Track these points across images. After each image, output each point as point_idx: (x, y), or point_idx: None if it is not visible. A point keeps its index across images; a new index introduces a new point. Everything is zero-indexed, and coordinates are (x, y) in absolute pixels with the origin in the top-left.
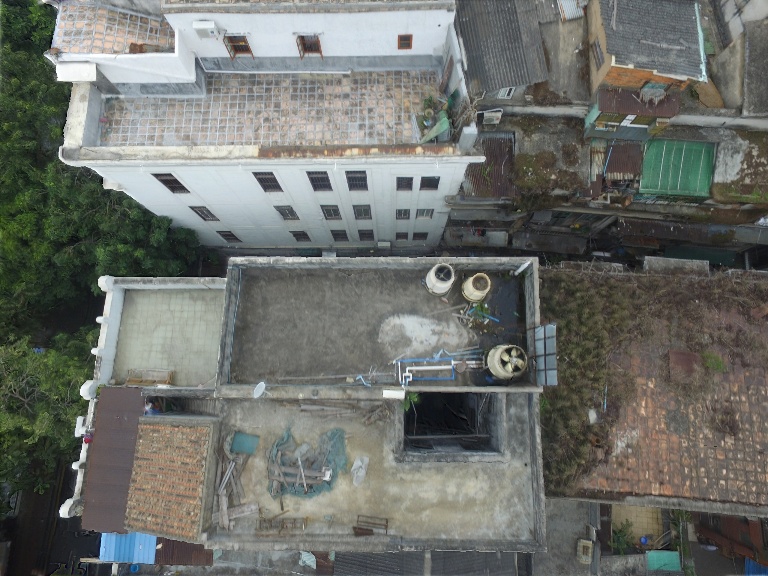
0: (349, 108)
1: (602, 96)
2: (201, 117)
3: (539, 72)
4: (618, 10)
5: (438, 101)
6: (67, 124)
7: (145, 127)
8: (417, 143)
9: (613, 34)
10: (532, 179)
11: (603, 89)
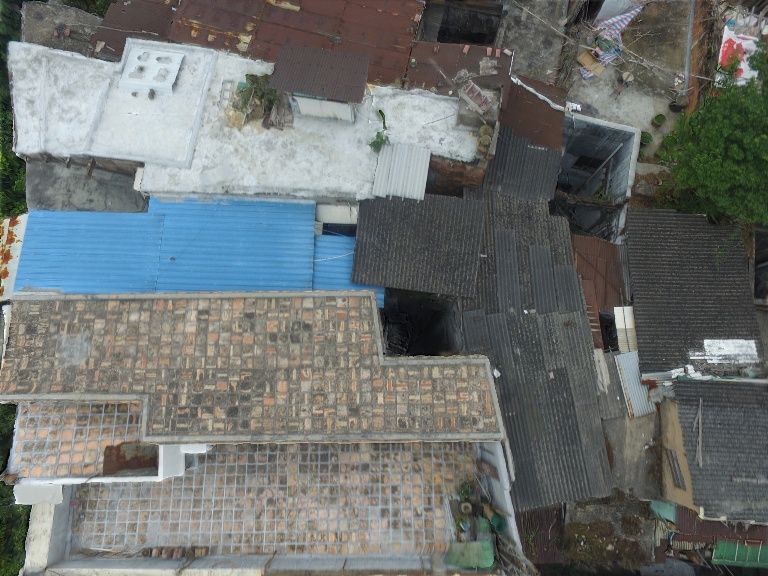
0: (369, 484)
1: (680, 514)
2: (192, 496)
3: (603, 485)
4: (703, 433)
5: (476, 479)
6: (29, 533)
7: (125, 512)
8: (452, 544)
9: (700, 473)
10: (585, 550)
11: (681, 507)
